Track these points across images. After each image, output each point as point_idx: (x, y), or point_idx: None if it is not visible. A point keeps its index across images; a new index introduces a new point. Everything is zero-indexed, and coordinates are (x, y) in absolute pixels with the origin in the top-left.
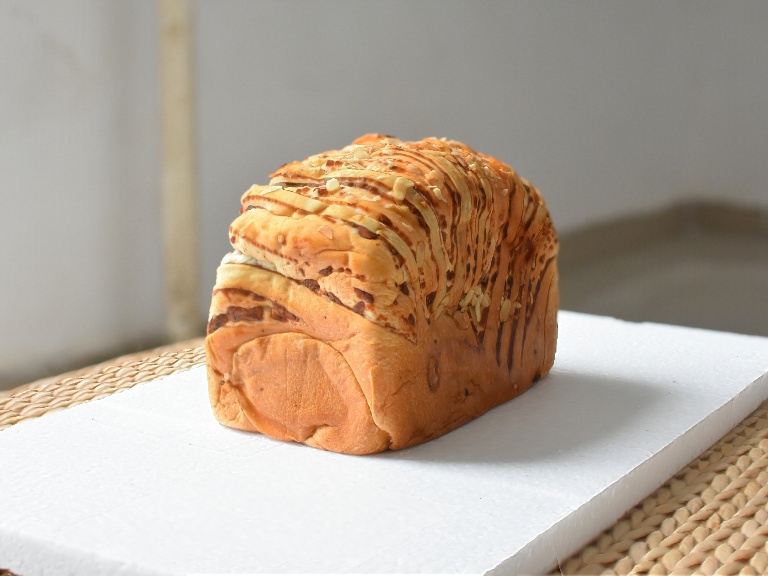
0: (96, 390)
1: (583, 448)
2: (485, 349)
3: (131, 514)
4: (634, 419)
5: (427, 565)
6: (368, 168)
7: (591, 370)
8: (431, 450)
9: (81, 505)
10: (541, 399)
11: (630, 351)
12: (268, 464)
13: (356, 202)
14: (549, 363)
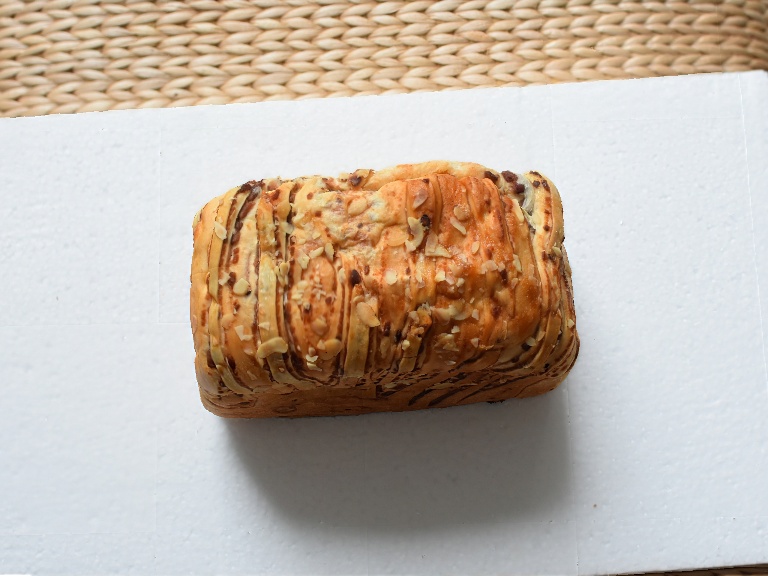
0: (317, 12)
1: (340, 536)
2: (389, 399)
3: (7, 346)
4: (447, 532)
5: (44, 574)
6: (299, 284)
7: (584, 416)
8: (261, 433)
9: (3, 302)
10: (458, 428)
11: (678, 415)
12: (153, 350)
13: (226, 328)
14: (528, 396)
